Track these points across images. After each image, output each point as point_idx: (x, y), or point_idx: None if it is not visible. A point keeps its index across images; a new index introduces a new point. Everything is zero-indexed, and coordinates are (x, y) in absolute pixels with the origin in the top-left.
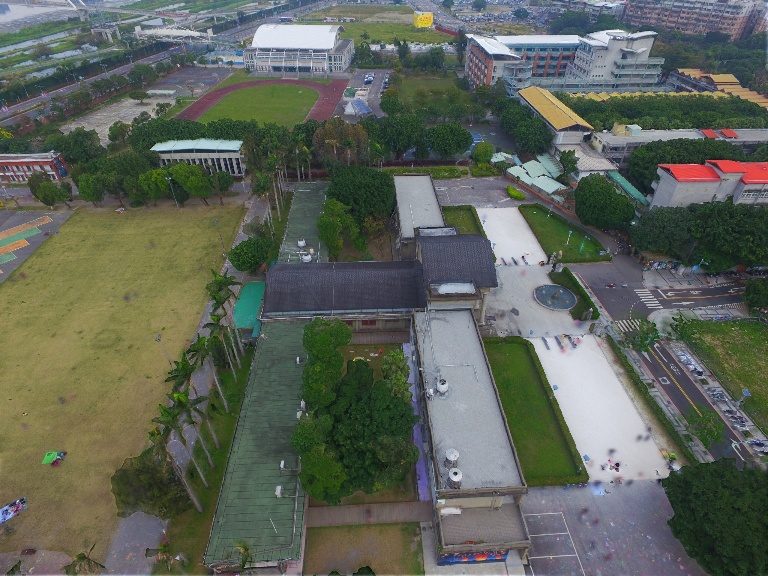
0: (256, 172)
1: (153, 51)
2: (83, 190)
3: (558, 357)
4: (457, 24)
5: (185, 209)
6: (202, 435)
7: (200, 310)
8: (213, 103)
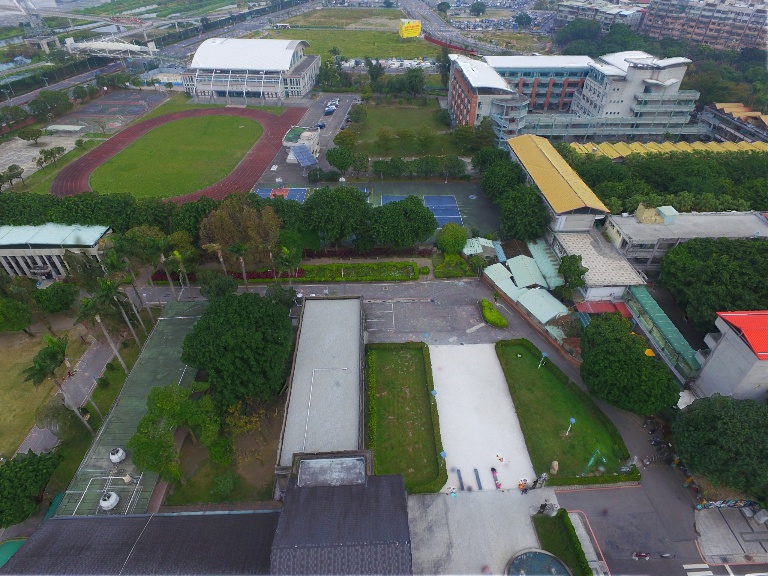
0: None
1: (86, 68)
2: None
3: None
4: (450, 32)
5: None
6: None
7: None
8: (126, 143)
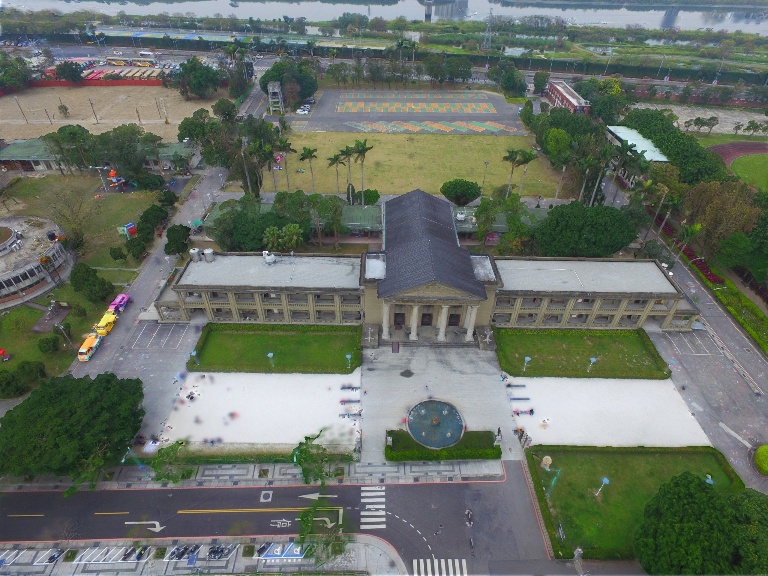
0: None
1: None
2: None
3: (329, 395)
4: None
5: (550, 171)
6: None
7: None
8: None
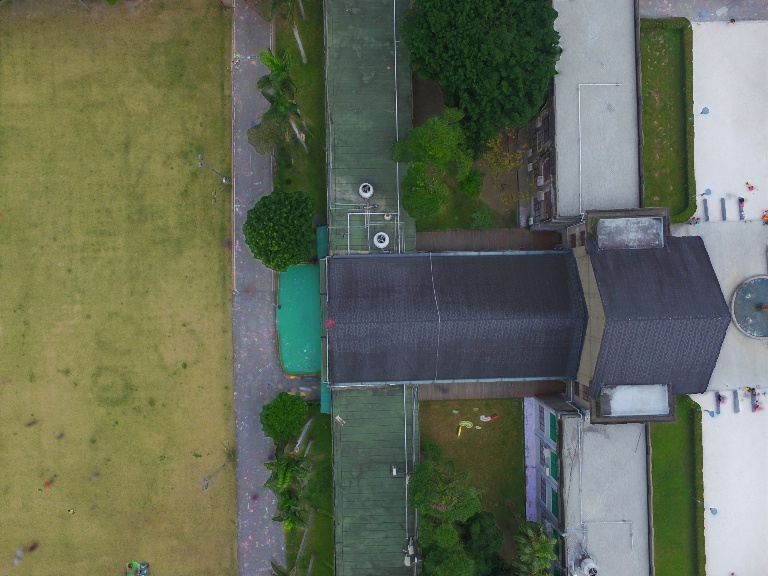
0: None
1: None
2: None
3: (726, 426)
4: None
5: (101, 8)
6: (291, 539)
7: (225, 324)
8: None
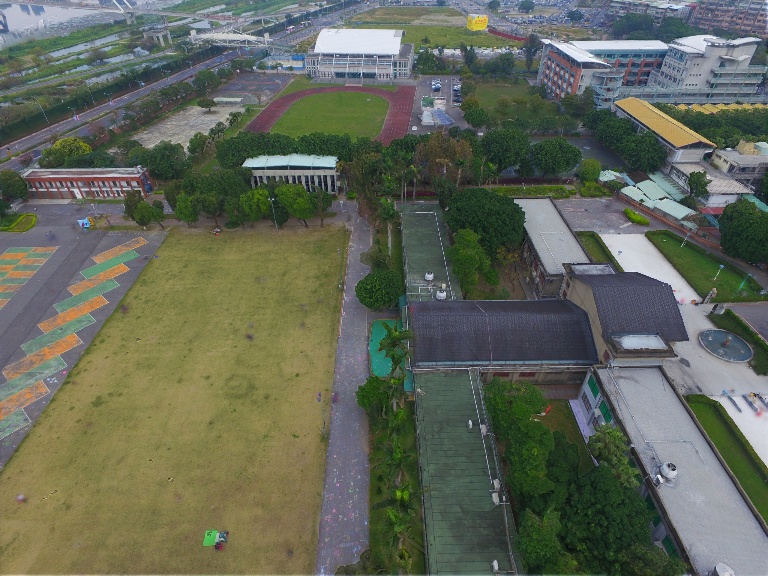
0: (366, 194)
1: (208, 56)
2: (181, 211)
3: (755, 422)
4: (509, 27)
5: (284, 231)
6: (375, 513)
7: (331, 353)
8: (282, 112)
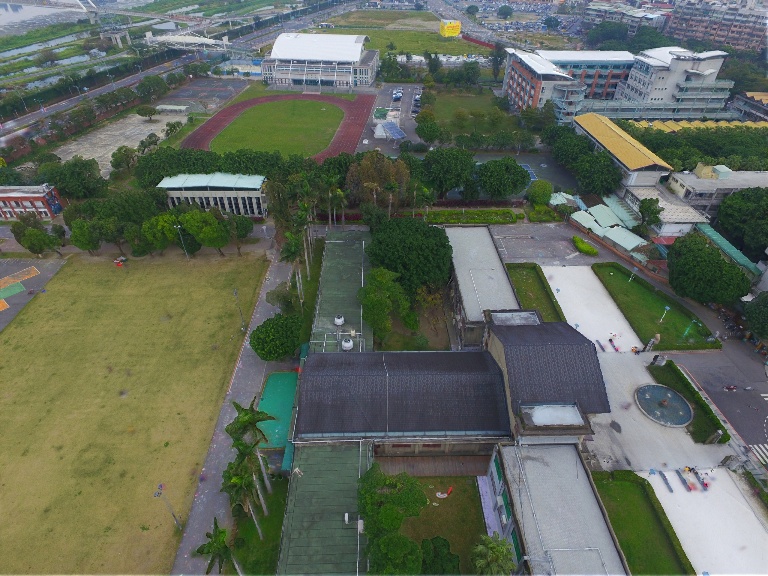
0: (282, 222)
1: (164, 59)
2: (76, 238)
3: (687, 505)
4: (484, 33)
5: (196, 260)
6: None
7: (213, 414)
8: (228, 121)
